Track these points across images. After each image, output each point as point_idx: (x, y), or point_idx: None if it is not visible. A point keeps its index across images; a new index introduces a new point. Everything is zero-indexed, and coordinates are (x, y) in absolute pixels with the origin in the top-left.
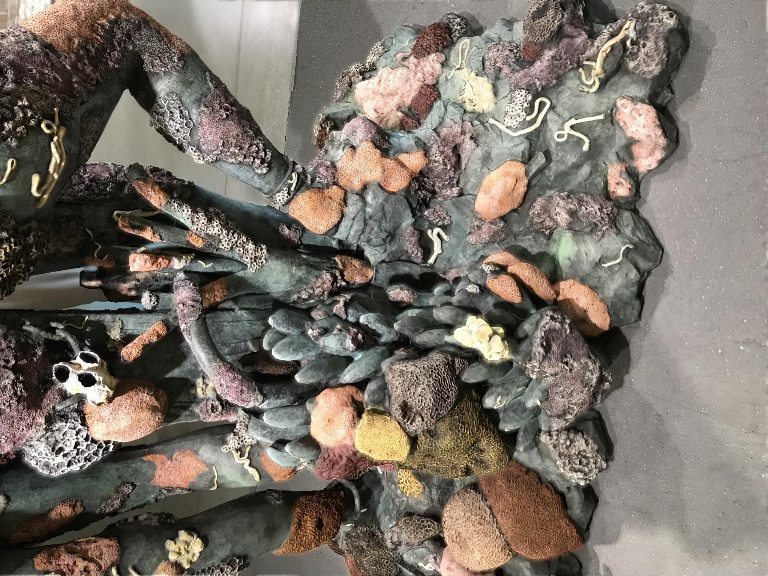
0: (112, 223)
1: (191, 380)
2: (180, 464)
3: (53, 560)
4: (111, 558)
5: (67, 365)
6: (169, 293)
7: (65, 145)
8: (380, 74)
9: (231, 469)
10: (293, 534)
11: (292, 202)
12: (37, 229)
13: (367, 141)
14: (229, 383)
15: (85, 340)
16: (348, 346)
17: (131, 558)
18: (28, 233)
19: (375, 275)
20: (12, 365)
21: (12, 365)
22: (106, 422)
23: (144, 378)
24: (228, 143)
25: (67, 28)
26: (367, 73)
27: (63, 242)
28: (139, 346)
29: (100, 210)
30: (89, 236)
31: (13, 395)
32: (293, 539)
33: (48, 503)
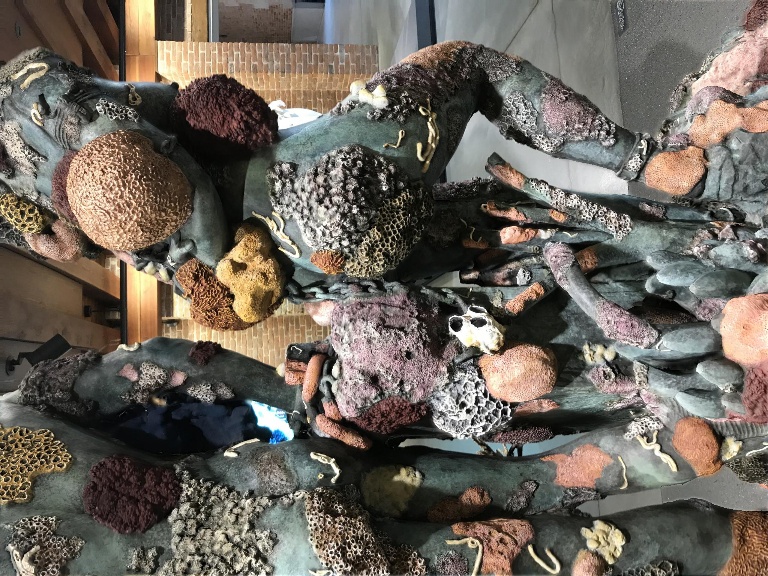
0: (481, 214)
1: (577, 347)
2: (581, 459)
3: (469, 528)
4: (525, 536)
5: (460, 316)
6: (541, 269)
7: (438, 127)
8: (715, 63)
9: (640, 458)
10: (738, 550)
11: (647, 167)
12: (424, 187)
13: (716, 101)
14: (617, 318)
15: (472, 303)
16: (747, 254)
17: (546, 540)
18: (418, 188)
19: (764, 227)
20: (416, 316)
21: (416, 316)
22: (501, 372)
23: (530, 342)
24: (572, 121)
25: (429, 56)
26: (701, 75)
27: (444, 231)
28: (520, 301)
29: (470, 204)
30: (464, 225)
31: (419, 338)
32: (740, 557)
33: (458, 486)
